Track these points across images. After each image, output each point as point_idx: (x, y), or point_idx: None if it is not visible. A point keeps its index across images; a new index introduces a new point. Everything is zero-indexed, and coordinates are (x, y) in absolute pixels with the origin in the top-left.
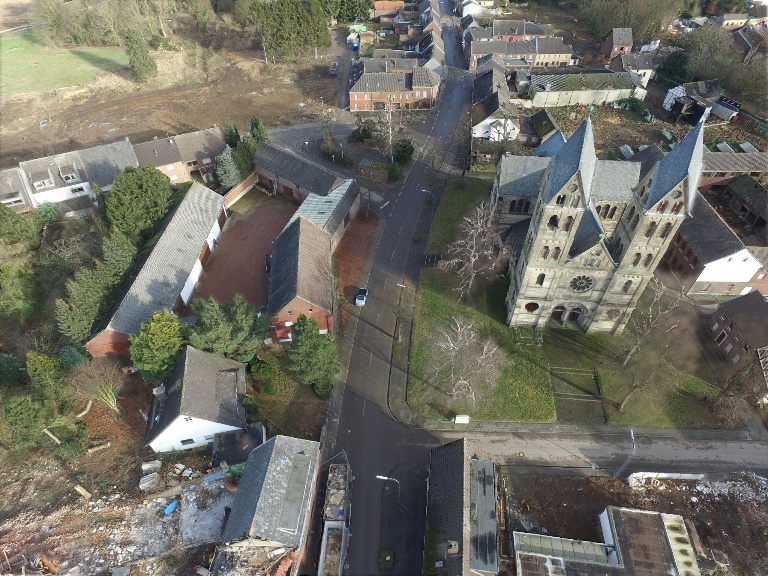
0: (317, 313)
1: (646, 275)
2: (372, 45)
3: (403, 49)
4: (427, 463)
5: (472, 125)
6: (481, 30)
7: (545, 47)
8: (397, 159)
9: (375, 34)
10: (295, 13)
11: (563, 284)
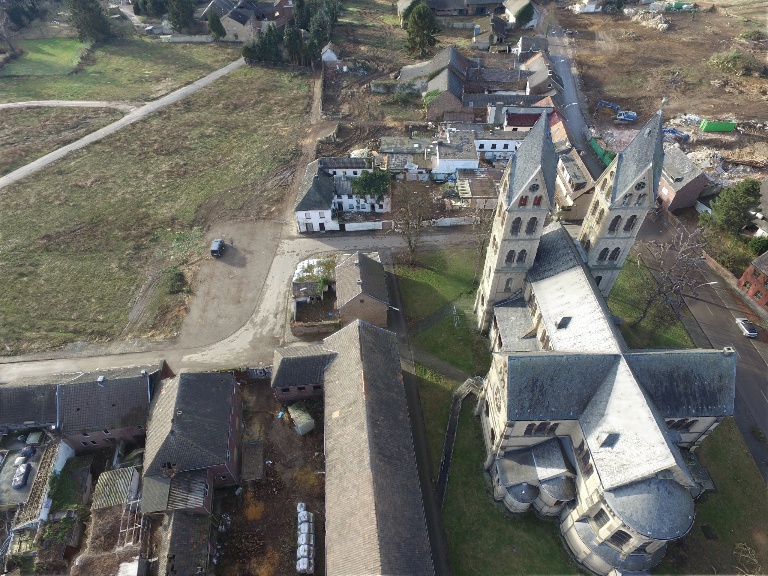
0: None
1: None
2: None
3: None
4: None
5: None
6: None
7: None
8: None
9: None
10: None
11: None
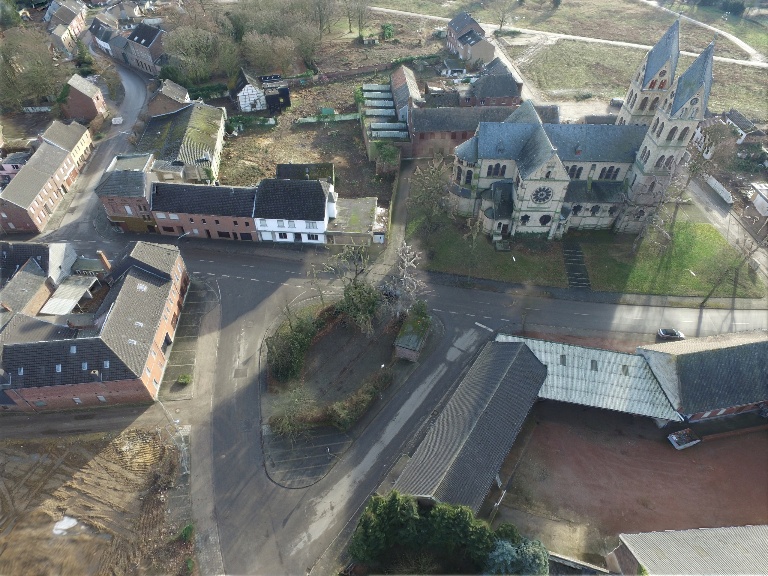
0: None
1: None
2: None
3: None
4: None
5: (319, 220)
6: None
7: (62, 141)
8: None
9: None
10: None
11: None
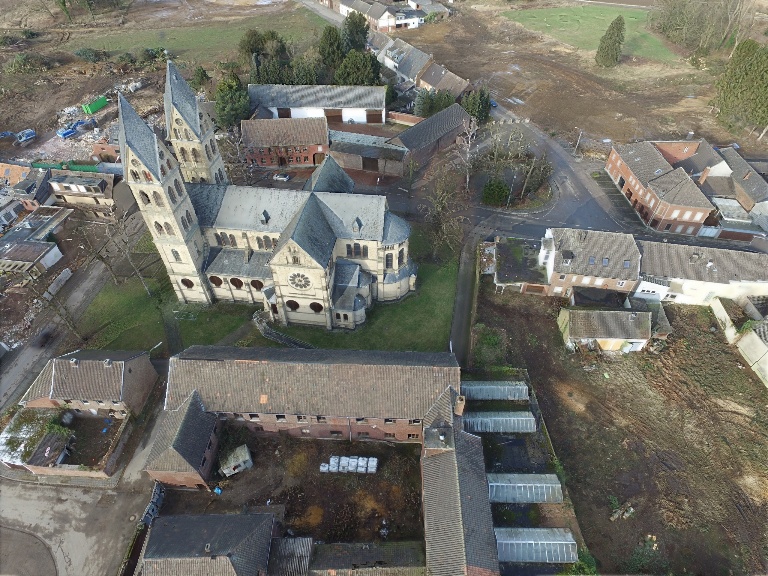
0: None
1: None
2: None
3: None
4: None
5: None
6: None
7: None
8: None
9: None
10: None
11: None
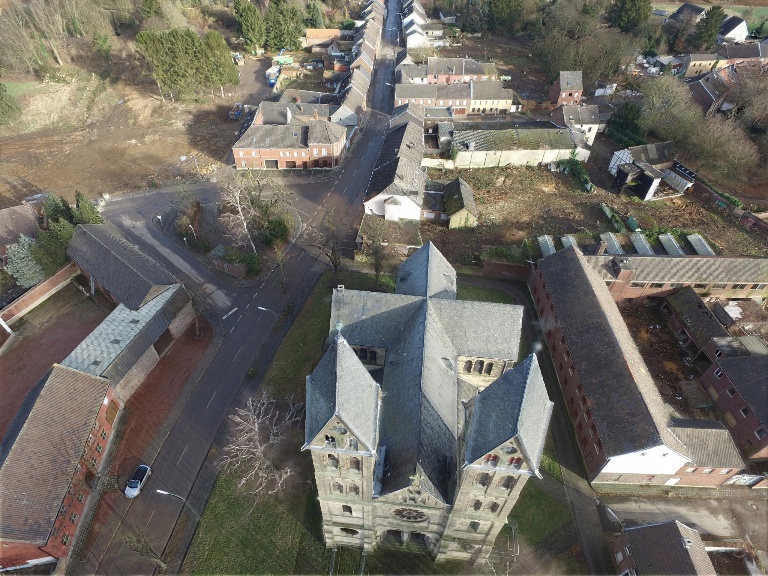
0: (19, 546)
1: (496, 521)
2: (294, 81)
3: (326, 87)
4: None
5: (364, 200)
6: (414, 68)
7: (481, 92)
8: (266, 243)
9: (299, 68)
10: (191, 47)
11: (383, 514)
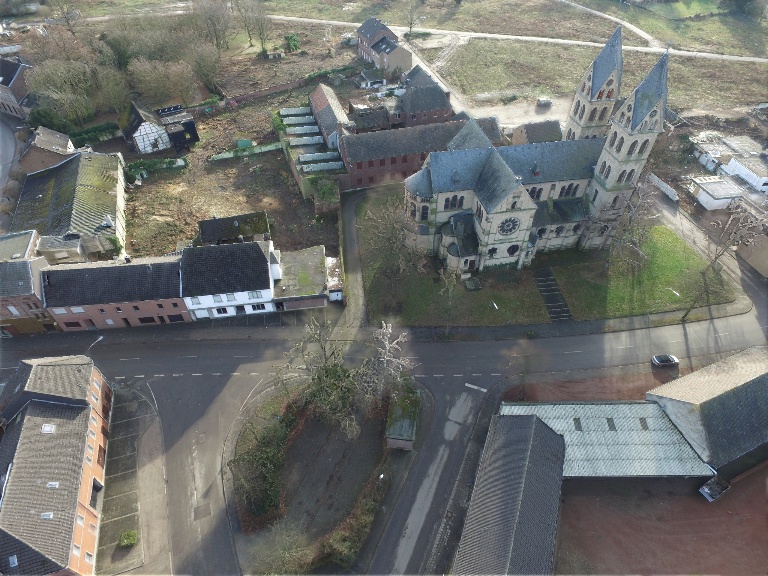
0: None
1: None
2: None
3: None
4: (763, 281)
5: (264, 289)
6: None
7: None
8: None
9: None
10: None
11: None
